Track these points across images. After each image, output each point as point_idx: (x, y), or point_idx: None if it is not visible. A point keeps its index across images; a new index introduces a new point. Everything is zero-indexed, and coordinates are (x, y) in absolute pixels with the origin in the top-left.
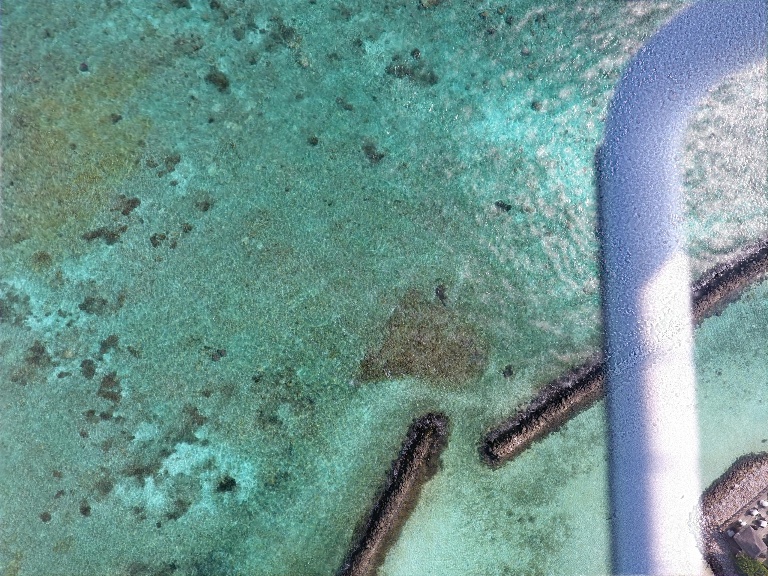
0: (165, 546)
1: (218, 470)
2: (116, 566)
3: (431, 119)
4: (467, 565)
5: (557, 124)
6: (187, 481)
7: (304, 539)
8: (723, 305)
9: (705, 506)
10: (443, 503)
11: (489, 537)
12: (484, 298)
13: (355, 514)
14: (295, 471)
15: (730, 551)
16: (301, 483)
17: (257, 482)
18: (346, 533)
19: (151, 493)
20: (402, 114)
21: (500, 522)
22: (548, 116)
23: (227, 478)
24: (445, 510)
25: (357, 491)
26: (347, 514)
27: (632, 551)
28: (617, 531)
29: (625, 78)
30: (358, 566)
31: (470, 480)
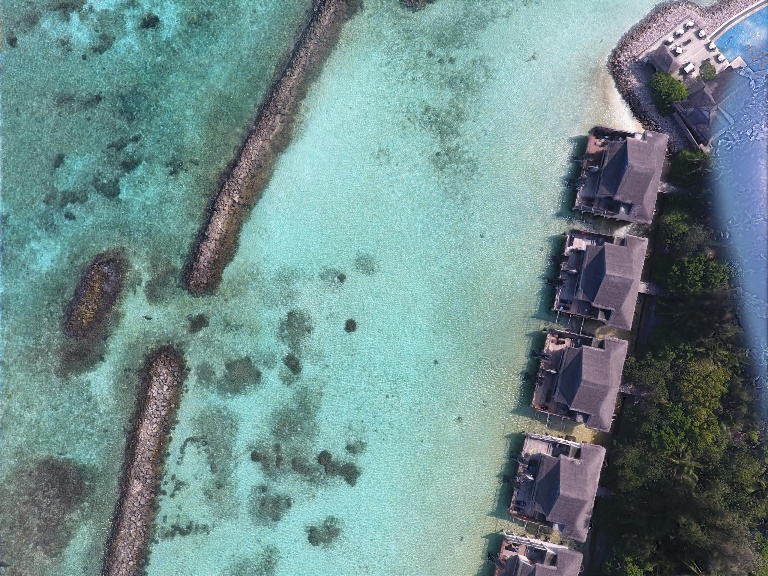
0: (91, 78)
1: (141, 6)
2: (43, 95)
3: None
4: (388, 103)
5: None
6: (111, 16)
7: (227, 75)
8: None
9: (623, 46)
10: (363, 43)
11: (409, 76)
12: None
13: (277, 51)
14: (217, 10)
15: (646, 80)
16: (223, 22)
17: (180, 19)
18: (268, 69)
19: (76, 27)
20: None
21: (420, 62)
22: None
23: (150, 14)
24: (366, 49)
25: (278, 29)
26: (269, 51)
27: (551, 92)
28: (536, 72)
29: None
30: (279, 92)
31: (390, 21)
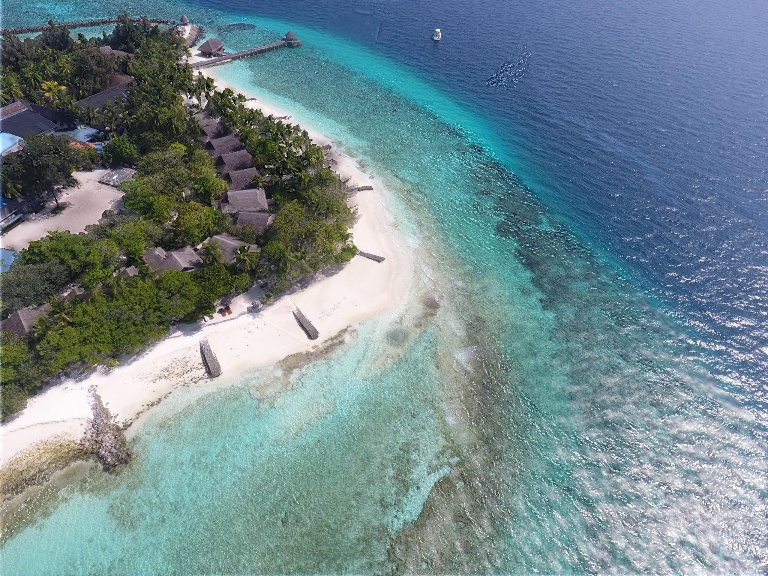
0: None
1: None
2: None
3: (19, 3)
4: None
5: (61, 6)
6: None
7: None
8: (91, 26)
9: None
10: None
11: None
12: (4, 20)
13: None
14: None
15: None
16: None
17: None
18: None
19: None
20: (10, 2)
21: None
22: (59, 5)
23: None
24: None
25: None
26: None
27: None
28: None
29: (90, 3)
30: None
31: None
